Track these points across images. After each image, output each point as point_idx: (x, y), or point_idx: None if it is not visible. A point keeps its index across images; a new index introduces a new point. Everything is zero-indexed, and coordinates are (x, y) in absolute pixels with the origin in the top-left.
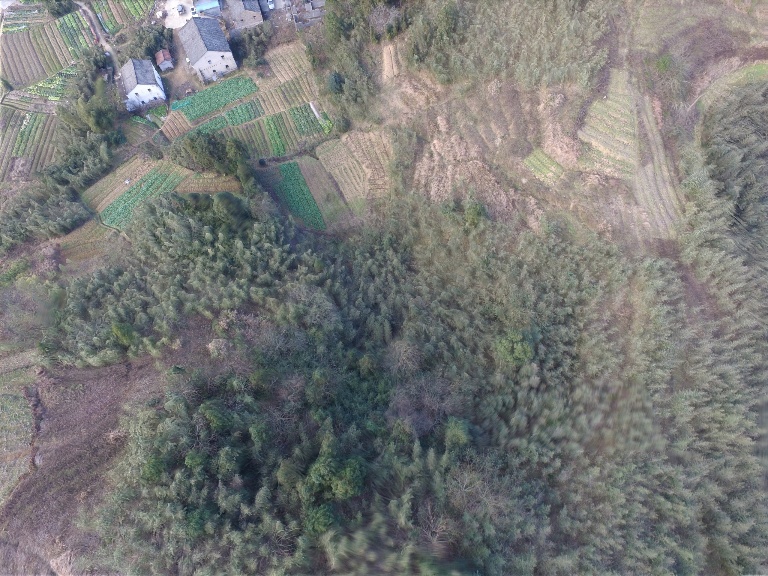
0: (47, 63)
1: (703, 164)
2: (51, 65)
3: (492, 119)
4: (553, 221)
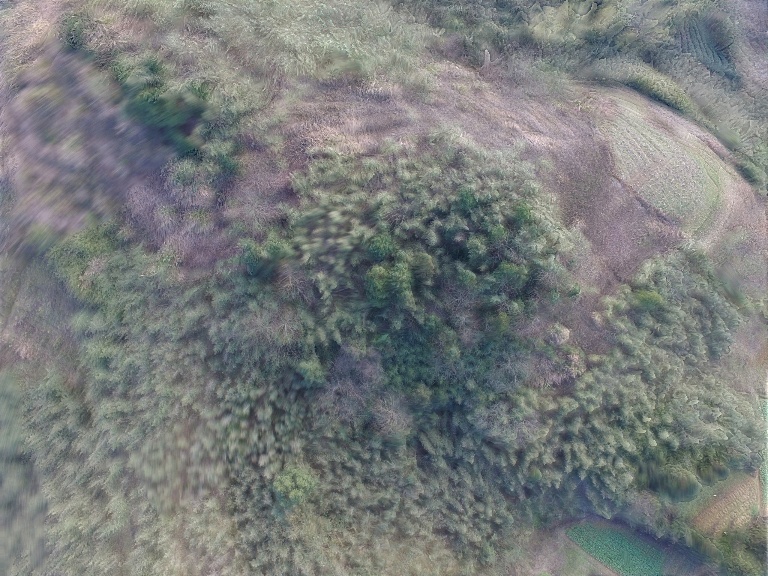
0: None
1: None
2: None
3: None
4: None
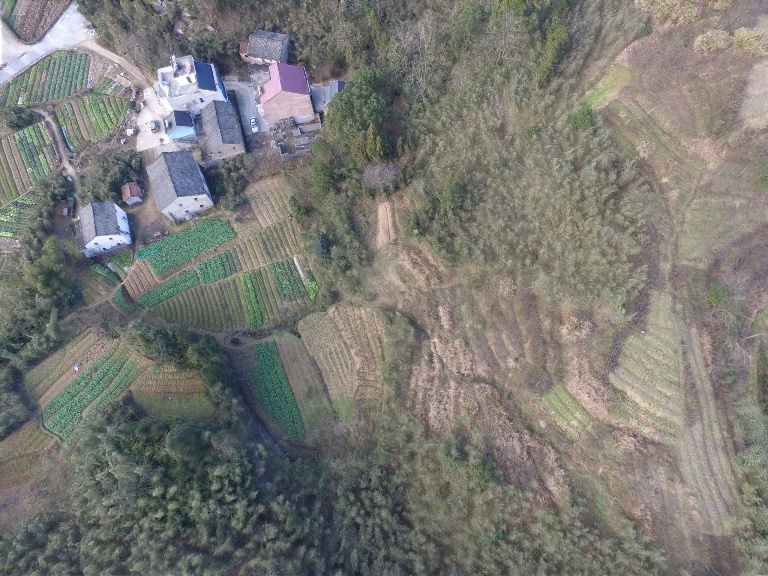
0: (2, 188)
1: (763, 422)
2: (6, 190)
3: (504, 330)
4: (577, 487)
